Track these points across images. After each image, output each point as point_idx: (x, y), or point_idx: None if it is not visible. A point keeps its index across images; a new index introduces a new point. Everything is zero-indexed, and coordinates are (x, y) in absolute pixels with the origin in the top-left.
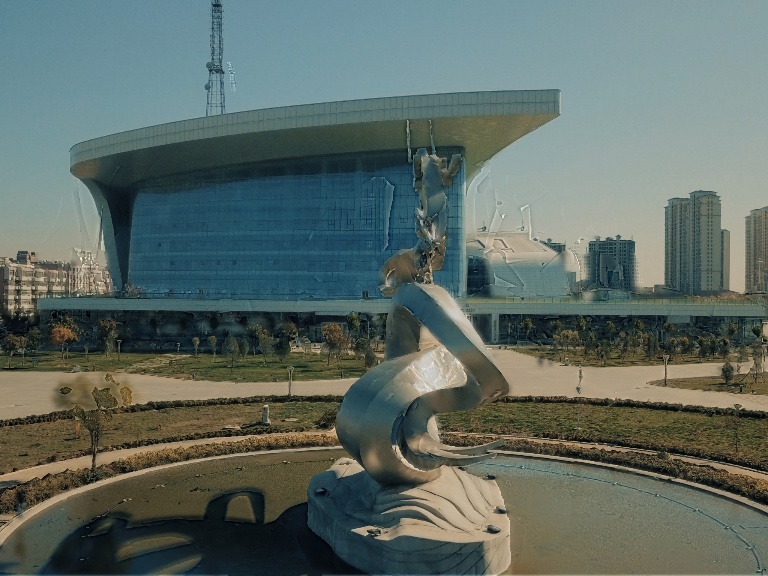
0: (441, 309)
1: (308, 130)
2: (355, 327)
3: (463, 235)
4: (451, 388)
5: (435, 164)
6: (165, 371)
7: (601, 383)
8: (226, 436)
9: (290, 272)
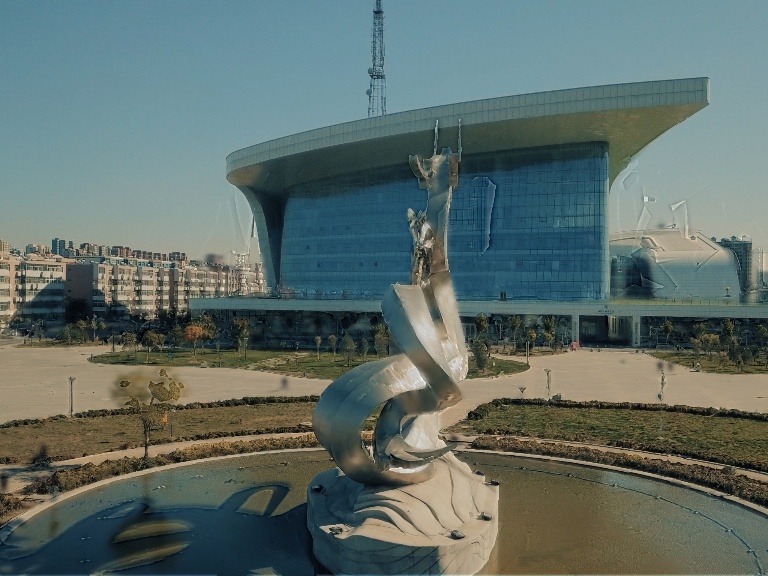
0: (403, 310)
1: (443, 131)
2: (484, 328)
3: (605, 234)
4: (416, 390)
5: (448, 164)
6: (283, 368)
7: (722, 391)
8: (294, 432)
9: None
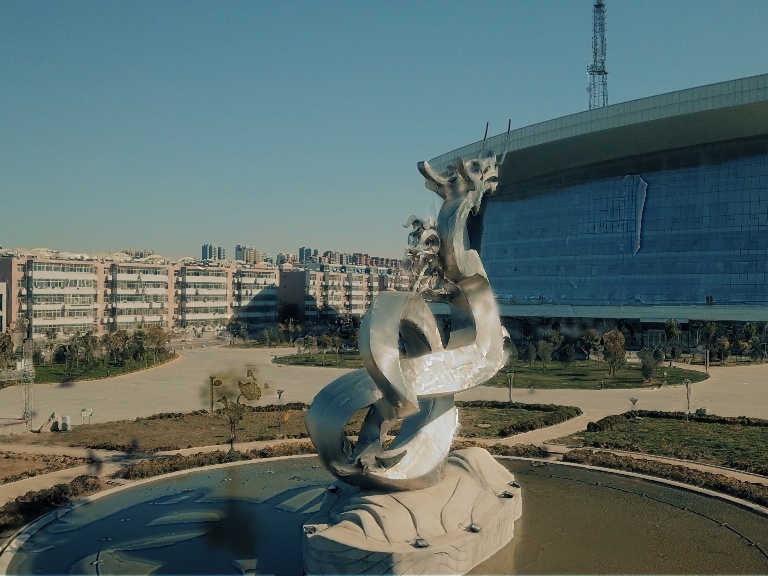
0: (369, 317)
1: (638, 126)
2: (674, 335)
3: None
4: None
5: None
6: None
7: None
8: None
9: (628, 276)
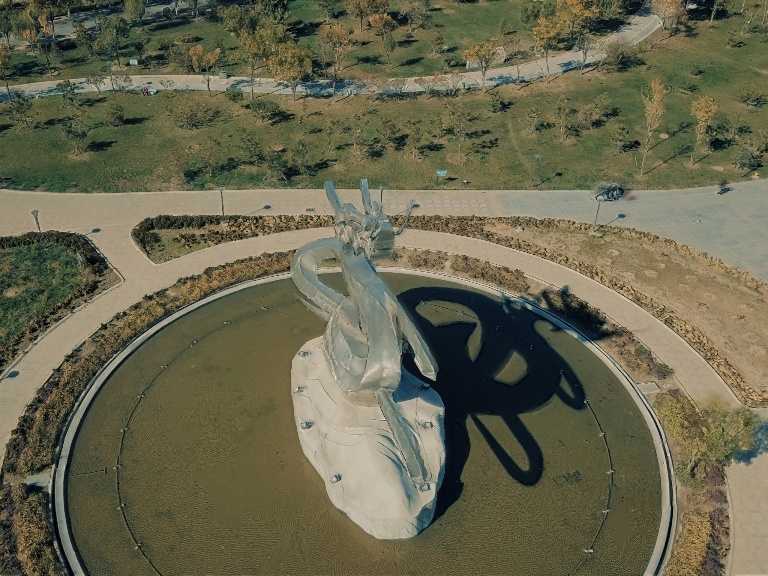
0: None
1: None
2: None
3: None
4: None
5: None
6: None
7: None
8: None
9: None
